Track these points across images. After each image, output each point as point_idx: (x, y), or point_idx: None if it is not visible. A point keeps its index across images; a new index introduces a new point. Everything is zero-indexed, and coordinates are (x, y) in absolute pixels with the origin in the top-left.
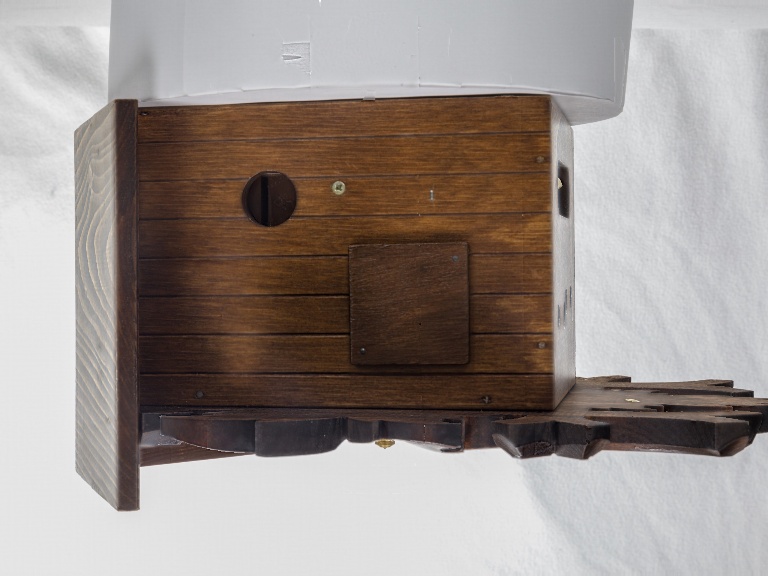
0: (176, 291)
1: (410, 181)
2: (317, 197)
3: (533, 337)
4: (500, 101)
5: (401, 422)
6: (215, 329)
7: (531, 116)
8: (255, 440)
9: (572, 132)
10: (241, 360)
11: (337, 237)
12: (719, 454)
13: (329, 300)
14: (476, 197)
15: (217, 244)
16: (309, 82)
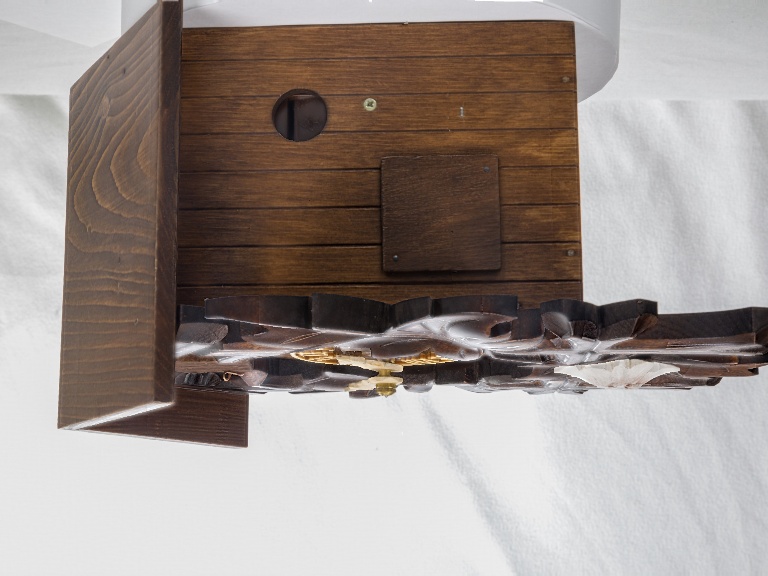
0: (202, 204)
1: (440, 99)
2: (348, 113)
3: (562, 245)
4: (527, 26)
5: (457, 296)
6: (242, 241)
7: (556, 40)
8: (312, 311)
9: None
10: (269, 271)
11: (368, 151)
12: (755, 339)
13: (360, 212)
14: (505, 114)
15: (246, 158)
16: None
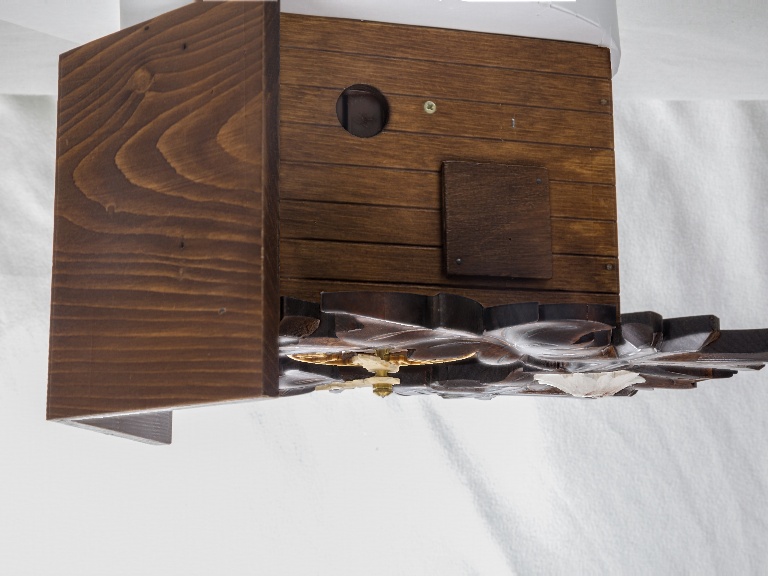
0: None
1: (494, 108)
2: (409, 114)
3: (602, 259)
4: (569, 47)
5: (562, 303)
6: (308, 234)
7: (595, 63)
8: (440, 310)
9: None
10: (335, 266)
11: (428, 153)
12: None
13: (421, 213)
14: (551, 129)
15: (311, 149)
16: None
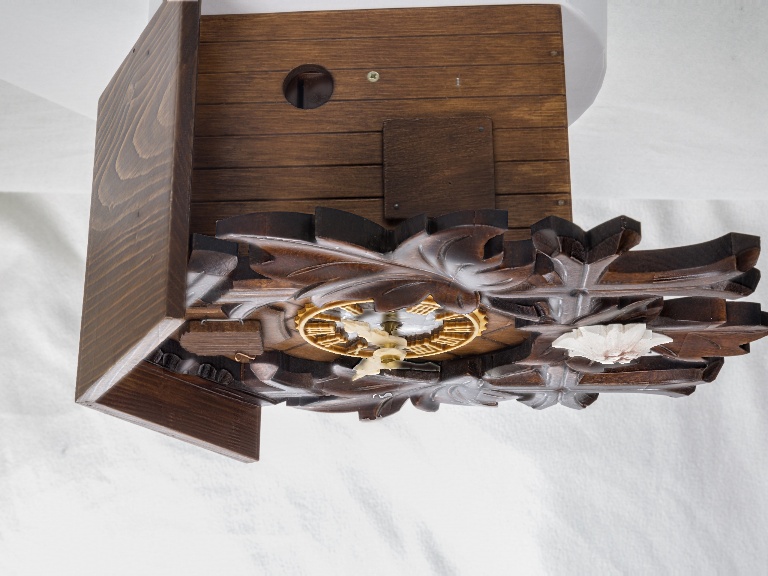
0: (217, 164)
1: (438, 71)
2: (353, 84)
3: (553, 196)
4: (517, 9)
5: None
6: (253, 196)
7: (544, 20)
8: (315, 222)
9: None
10: None
11: (371, 117)
12: (735, 264)
13: (363, 169)
14: (498, 83)
15: (258, 124)
16: None
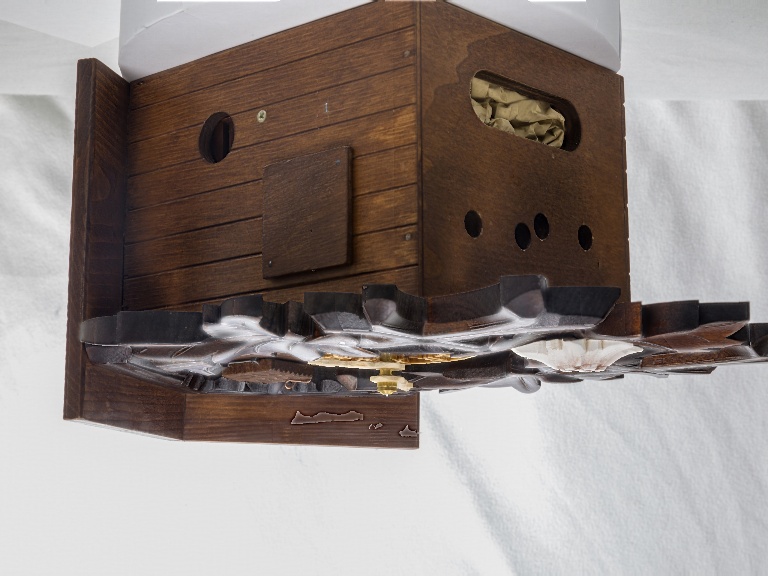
0: (155, 234)
1: (311, 98)
2: (248, 128)
3: (401, 230)
4: (377, 6)
5: None
6: (178, 263)
7: (400, 14)
8: None
9: (610, 75)
10: (194, 289)
11: (260, 162)
12: (514, 313)
13: (254, 222)
14: (359, 102)
15: (182, 186)
16: (182, 6)
